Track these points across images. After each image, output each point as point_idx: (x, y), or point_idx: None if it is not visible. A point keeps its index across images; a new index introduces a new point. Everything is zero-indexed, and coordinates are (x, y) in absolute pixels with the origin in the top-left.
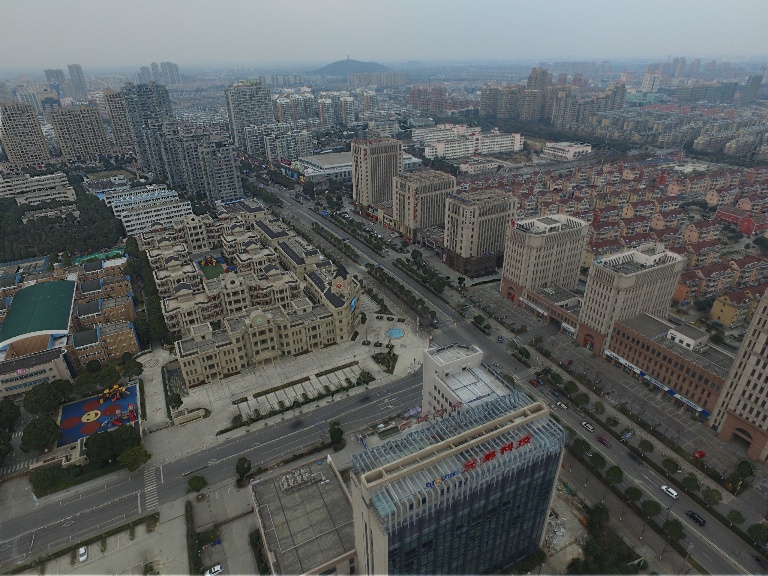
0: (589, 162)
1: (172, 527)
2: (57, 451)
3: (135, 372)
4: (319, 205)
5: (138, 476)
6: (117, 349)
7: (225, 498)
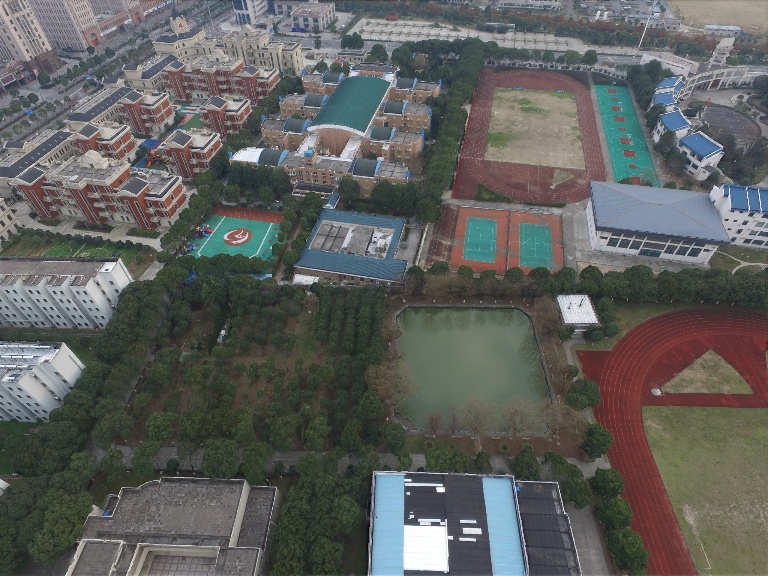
0: None
1: None
2: None
3: None
4: None
5: None
6: None
7: None
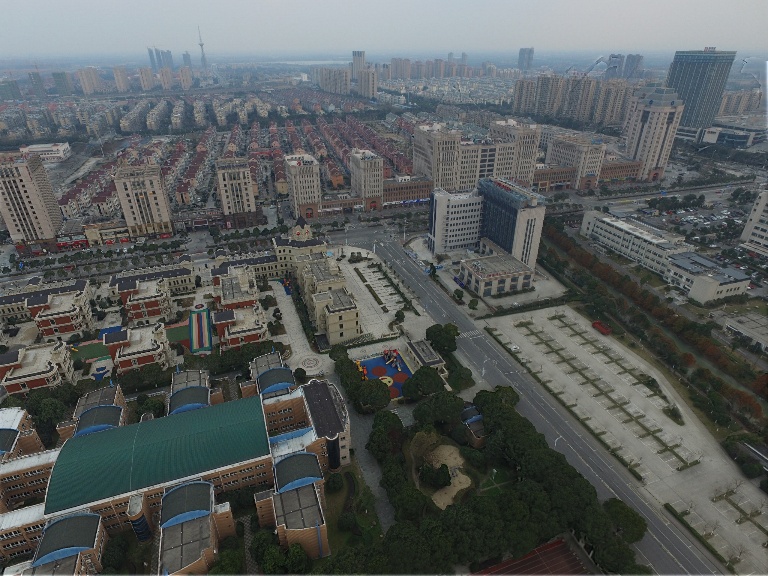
0: (86, 156)
1: (493, 322)
2: None
3: None
4: None
5: (455, 341)
6: None
7: None
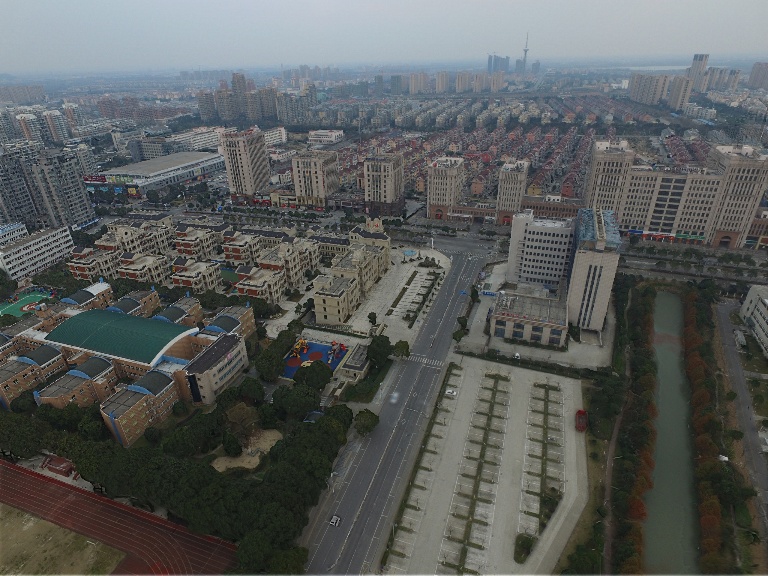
0: (349, 142)
1: (468, 362)
2: (328, 386)
3: (303, 326)
4: (193, 206)
5: (407, 362)
6: (244, 330)
7: (468, 341)
